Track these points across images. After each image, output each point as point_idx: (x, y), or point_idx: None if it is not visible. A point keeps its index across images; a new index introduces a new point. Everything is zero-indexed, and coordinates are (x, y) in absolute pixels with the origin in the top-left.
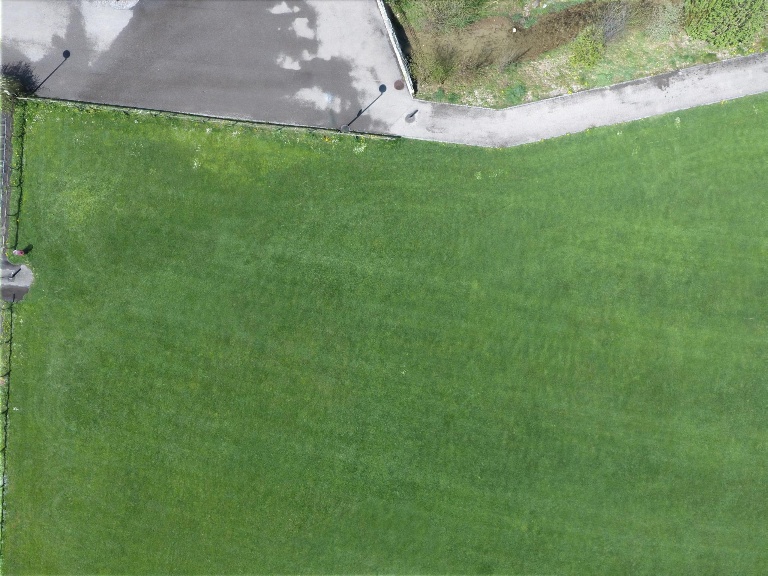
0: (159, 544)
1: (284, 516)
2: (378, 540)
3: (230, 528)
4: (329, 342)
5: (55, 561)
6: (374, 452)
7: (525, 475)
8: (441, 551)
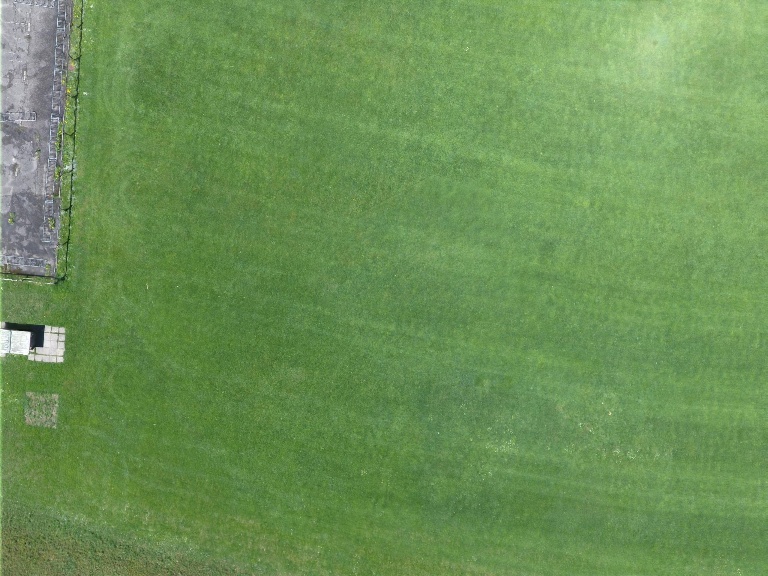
0: (225, 227)
1: (348, 196)
2: (441, 218)
3: (295, 209)
4: (393, 21)
5: (122, 246)
6: (437, 129)
7: (587, 148)
8: (503, 228)
